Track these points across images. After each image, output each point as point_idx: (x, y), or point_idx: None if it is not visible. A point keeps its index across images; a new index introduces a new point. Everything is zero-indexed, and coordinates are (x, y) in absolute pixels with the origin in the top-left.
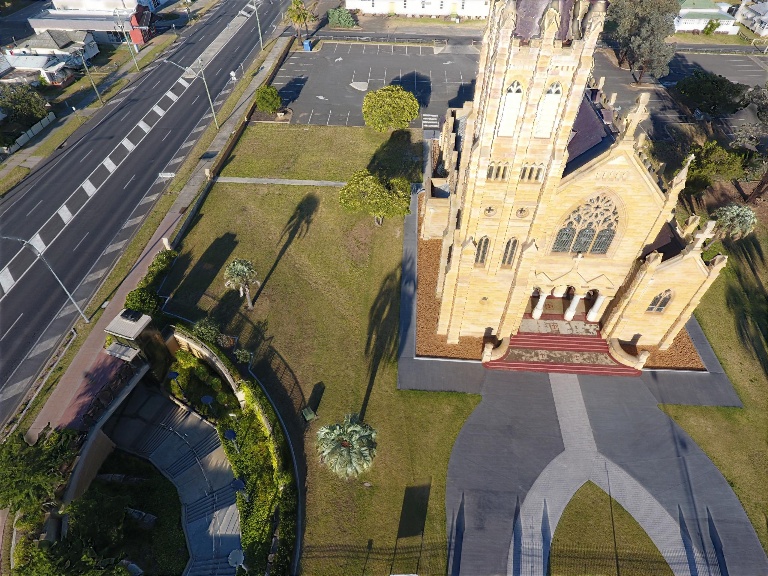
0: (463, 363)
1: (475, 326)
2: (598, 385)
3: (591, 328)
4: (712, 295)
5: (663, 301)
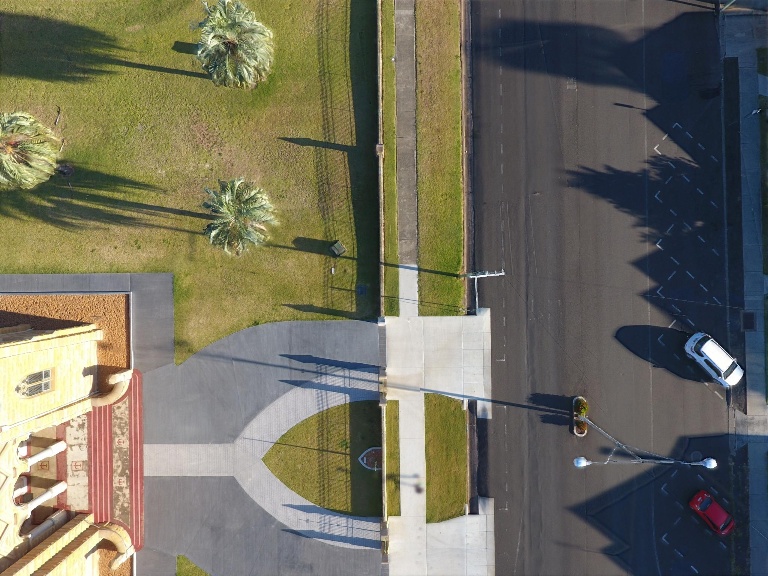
0: (137, 574)
1: (84, 574)
2: (156, 424)
3: (76, 421)
4: (8, 235)
5: (34, 380)
